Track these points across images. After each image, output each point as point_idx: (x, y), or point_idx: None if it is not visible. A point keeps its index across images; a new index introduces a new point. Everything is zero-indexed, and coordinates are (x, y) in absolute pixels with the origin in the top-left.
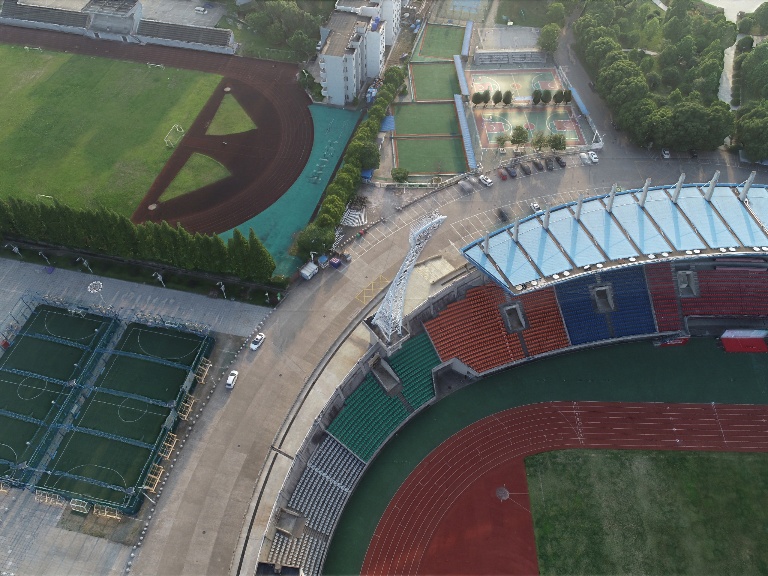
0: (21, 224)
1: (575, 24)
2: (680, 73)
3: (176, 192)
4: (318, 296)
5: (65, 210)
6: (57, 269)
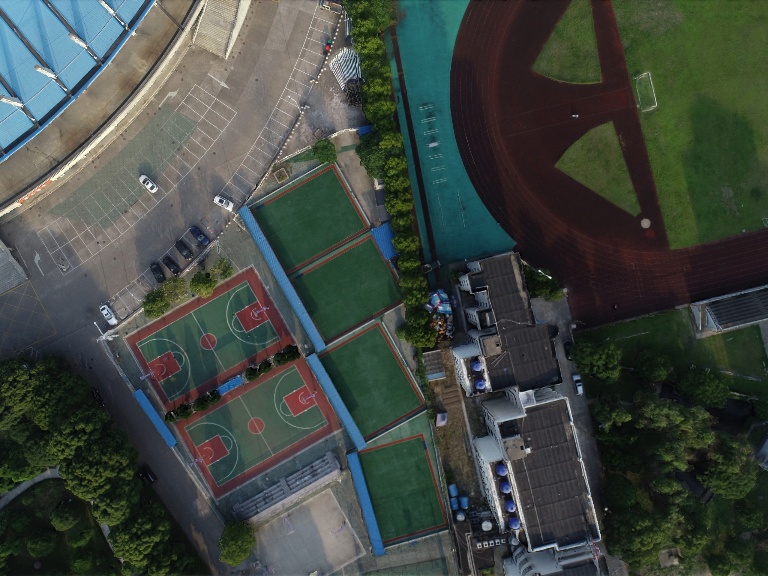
0: None
1: None
2: (35, 572)
3: (576, 9)
4: None
5: None
6: None
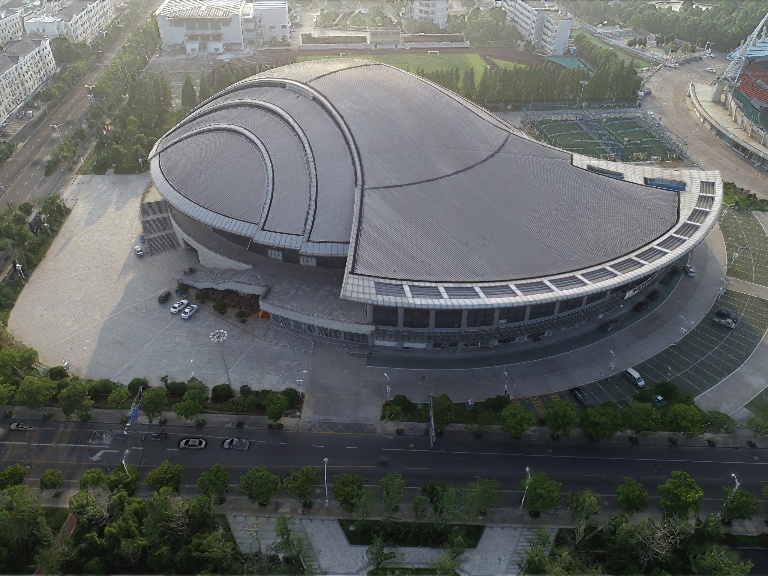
0: (486, 87)
1: (644, 16)
2: None
3: None
4: (655, 102)
5: (519, 70)
6: (509, 112)
